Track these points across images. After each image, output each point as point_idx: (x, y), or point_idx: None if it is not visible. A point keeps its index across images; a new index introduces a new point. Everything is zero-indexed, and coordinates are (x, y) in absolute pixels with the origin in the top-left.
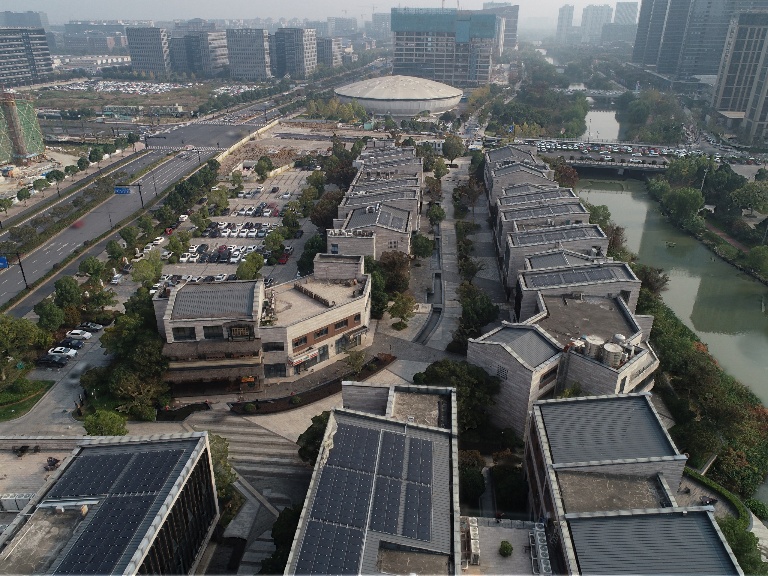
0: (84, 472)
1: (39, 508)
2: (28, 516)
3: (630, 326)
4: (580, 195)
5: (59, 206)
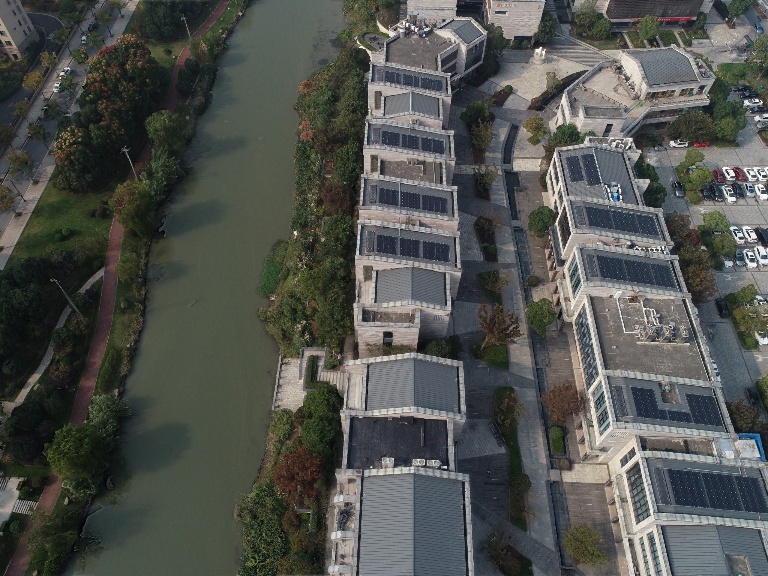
0: None
1: None
2: None
3: (388, 51)
4: None
5: None
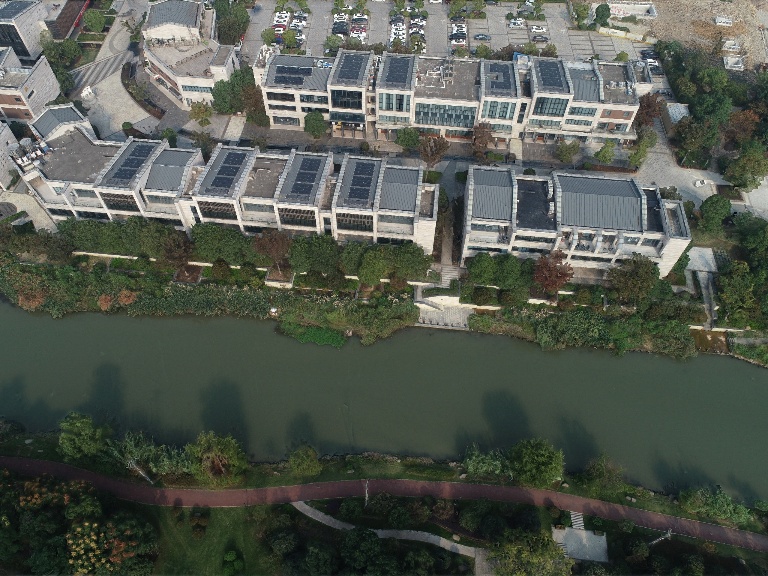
0: (20, 4)
1: (8, 1)
2: (6, 0)
3: None
4: (665, 362)
5: None
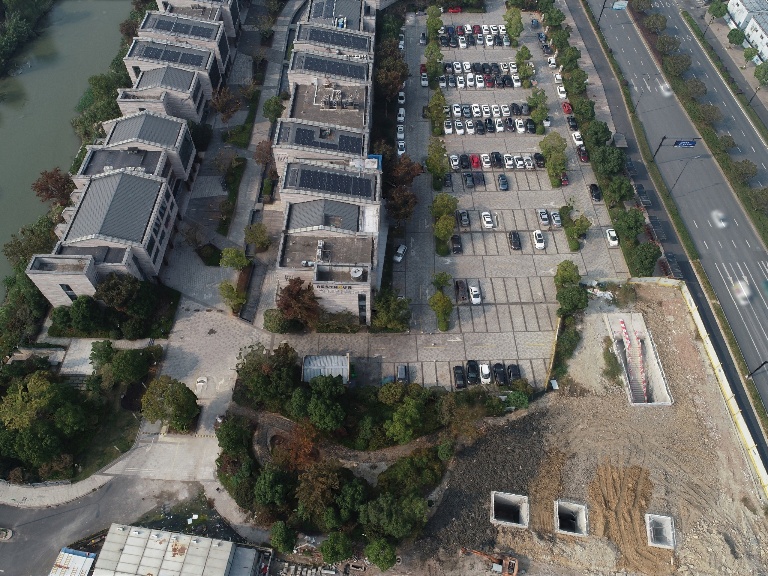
0: None
1: None
2: None
3: None
4: None
5: (723, 117)
